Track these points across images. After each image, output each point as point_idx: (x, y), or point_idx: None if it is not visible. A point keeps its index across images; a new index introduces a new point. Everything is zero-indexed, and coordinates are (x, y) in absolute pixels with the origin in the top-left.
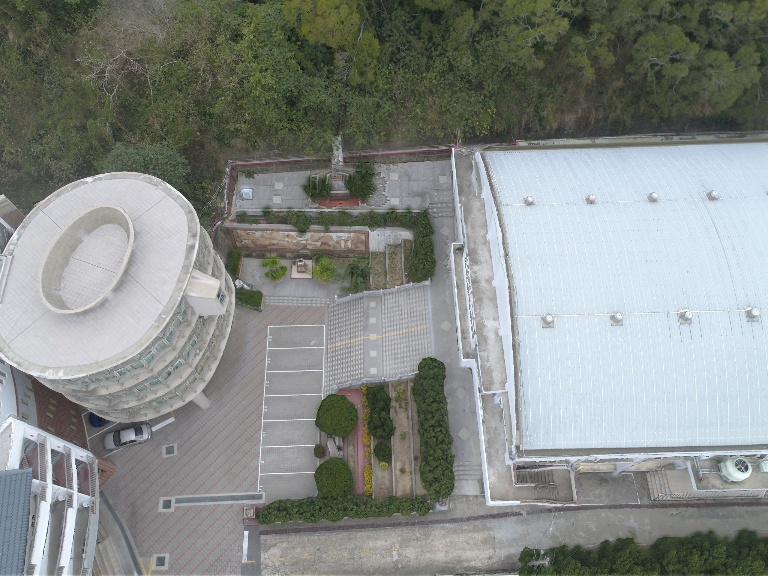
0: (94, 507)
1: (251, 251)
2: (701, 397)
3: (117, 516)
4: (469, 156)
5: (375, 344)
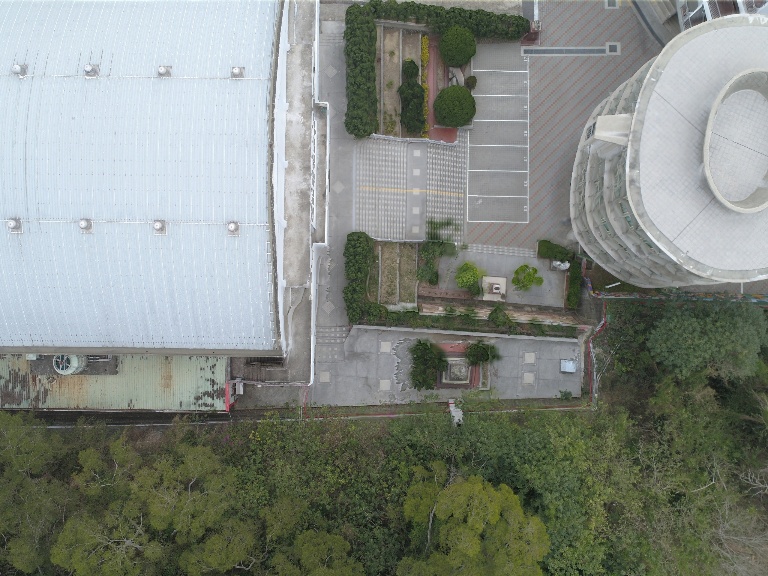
0: (683, 14)
1: (555, 314)
2: (99, 7)
3: (658, 41)
4: (291, 379)
5: (414, 183)
